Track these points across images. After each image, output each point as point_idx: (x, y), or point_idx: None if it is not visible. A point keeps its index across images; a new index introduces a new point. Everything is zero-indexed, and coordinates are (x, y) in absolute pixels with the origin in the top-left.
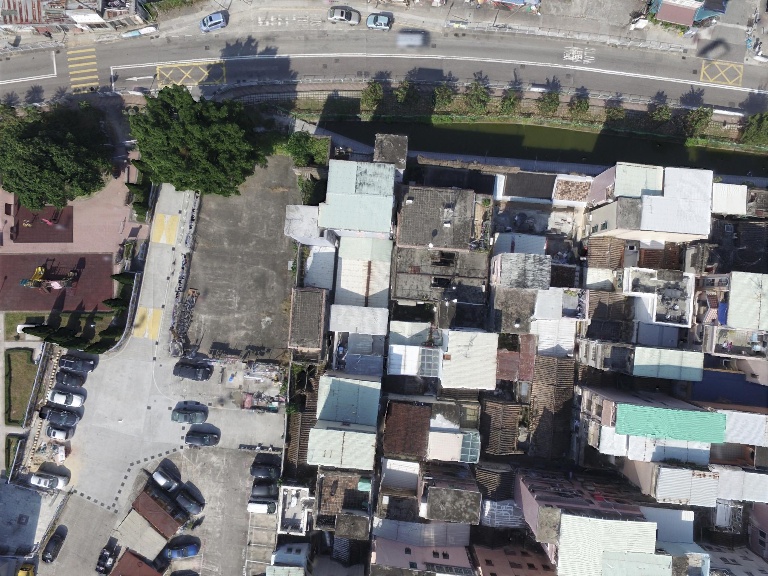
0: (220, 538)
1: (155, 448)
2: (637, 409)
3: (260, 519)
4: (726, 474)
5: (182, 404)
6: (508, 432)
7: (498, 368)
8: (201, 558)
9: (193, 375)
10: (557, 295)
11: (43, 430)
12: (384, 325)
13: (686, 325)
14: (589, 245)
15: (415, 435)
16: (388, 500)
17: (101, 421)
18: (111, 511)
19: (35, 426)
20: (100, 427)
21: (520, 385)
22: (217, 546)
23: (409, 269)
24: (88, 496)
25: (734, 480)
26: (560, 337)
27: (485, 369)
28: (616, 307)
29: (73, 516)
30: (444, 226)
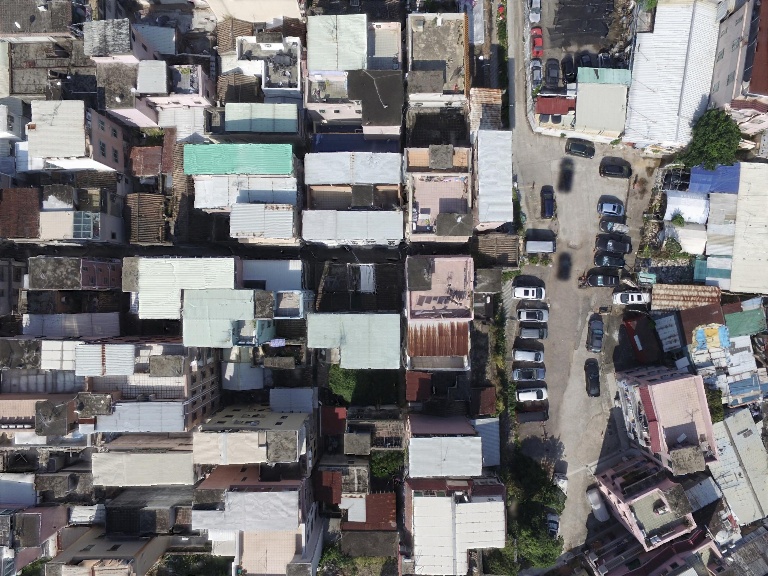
0: None
1: None
2: (201, 147)
3: None
4: (318, 215)
5: None
6: (151, 222)
7: (142, 164)
8: None
9: None
10: (159, 68)
11: None
12: (4, 121)
13: (295, 88)
14: (217, 32)
15: (26, 217)
16: (26, 294)
17: None
18: None
19: None
20: None
21: (165, 178)
22: None
23: (24, 64)
24: None
25: (326, 220)
26: (197, 125)
27: (73, 136)
28: (246, 89)
29: None
30: (40, 11)
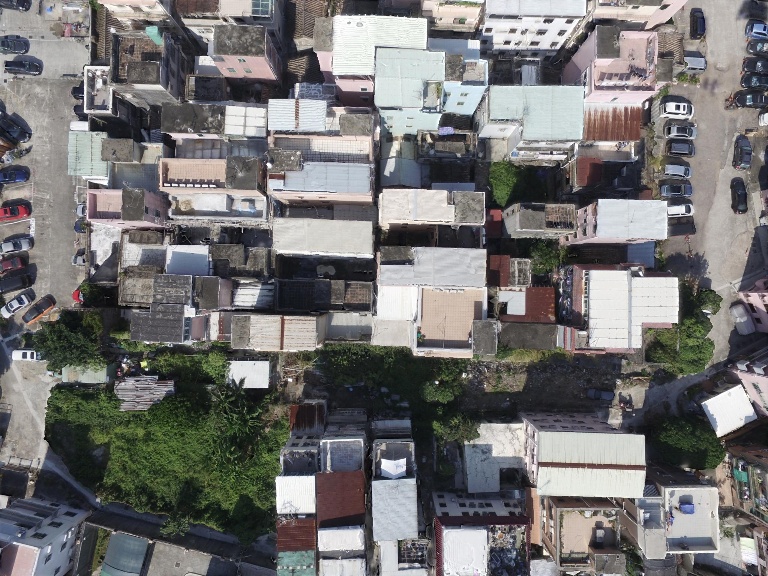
0: (49, 166)
1: None
2: None
3: None
4: None
5: (3, 39)
6: None
7: None
8: (31, 186)
9: None
10: None
11: None
12: None
13: None
14: None
15: None
16: (194, 80)
17: None
18: None
19: None
20: None
21: None
22: (47, 174)
23: None
24: None
25: None
26: None
27: None
28: None
29: None
30: None
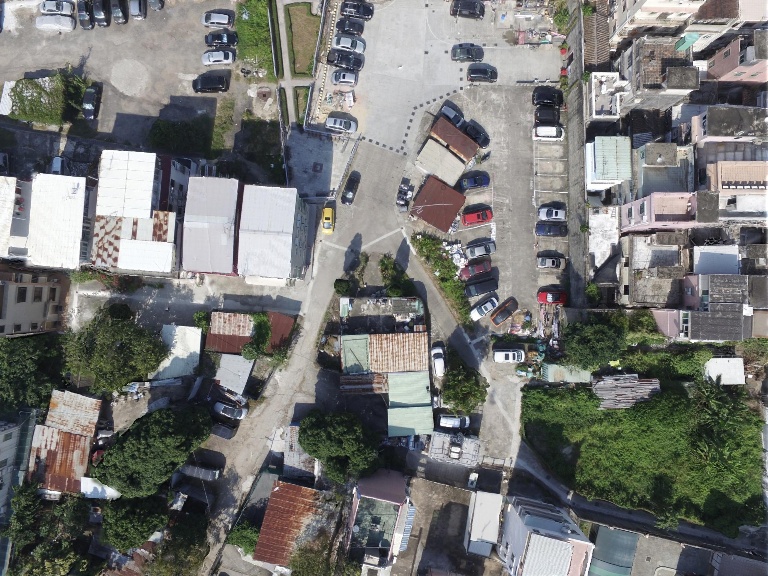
0: (507, 171)
1: (436, 91)
2: None
3: (544, 150)
4: None
5: (457, 47)
6: None
7: None
8: (491, 191)
9: (473, 8)
10: None
11: (327, 81)
12: None
13: None
14: None
15: None
16: None
17: (382, 69)
18: (400, 154)
19: (319, 78)
20: (381, 74)
21: None
22: (505, 179)
23: None
24: (376, 142)
25: None
26: None
27: None
28: None
29: (364, 161)
30: None
